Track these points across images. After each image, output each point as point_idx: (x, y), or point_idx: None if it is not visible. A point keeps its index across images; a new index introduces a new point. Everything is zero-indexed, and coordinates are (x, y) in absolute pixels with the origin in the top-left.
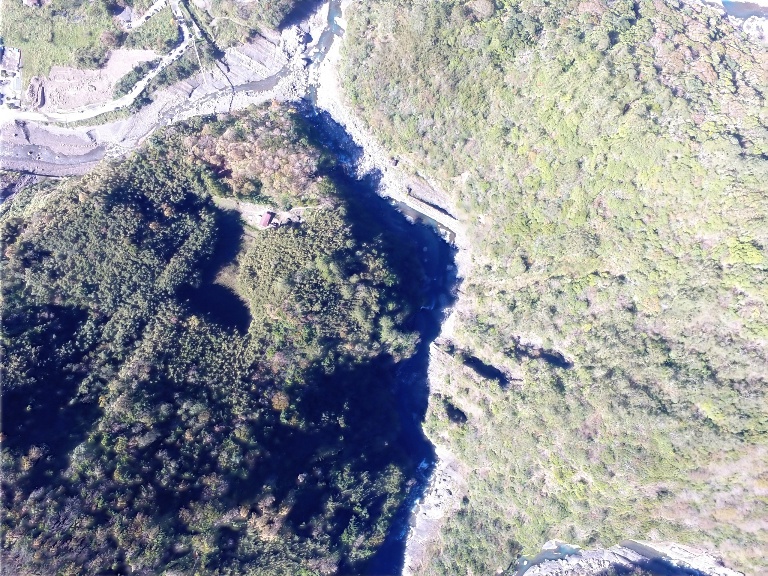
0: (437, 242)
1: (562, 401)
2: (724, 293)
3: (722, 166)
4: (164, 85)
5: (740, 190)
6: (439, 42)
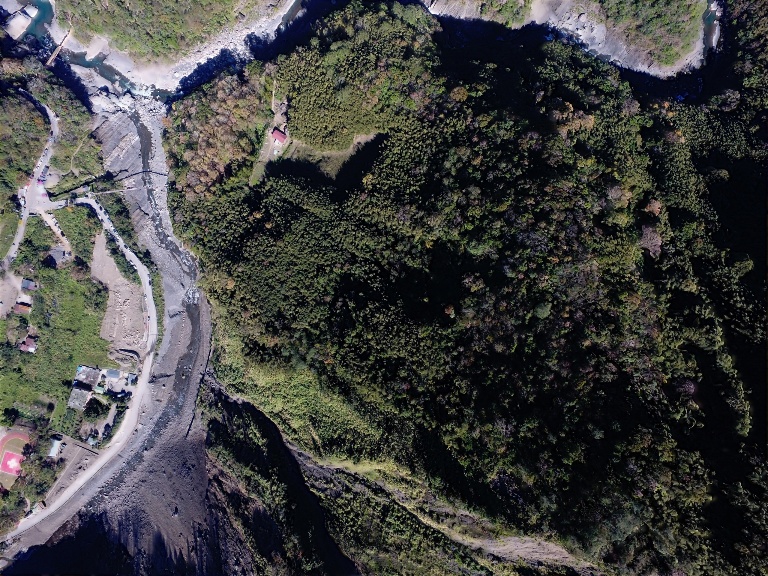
0: None
1: None
2: None
3: None
4: (133, 234)
5: None
6: None
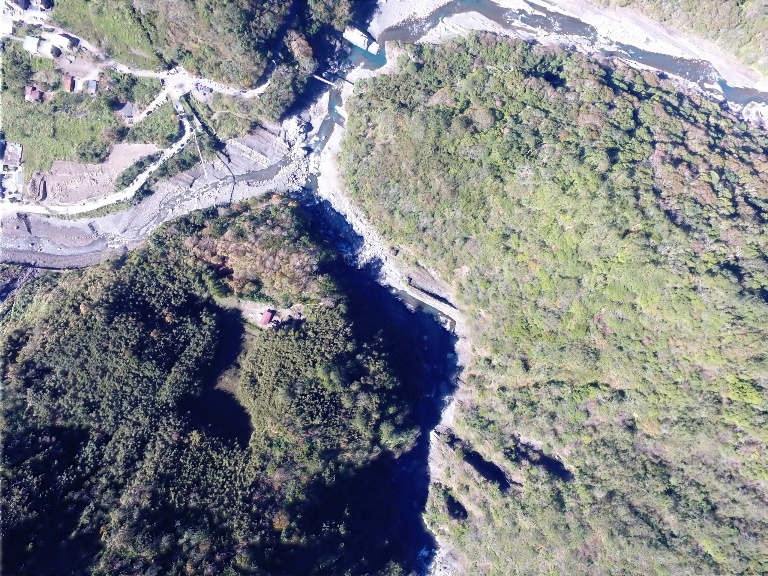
0: (437, 330)
1: (562, 518)
2: (724, 430)
3: (721, 302)
4: (165, 177)
5: (739, 328)
6: (439, 150)
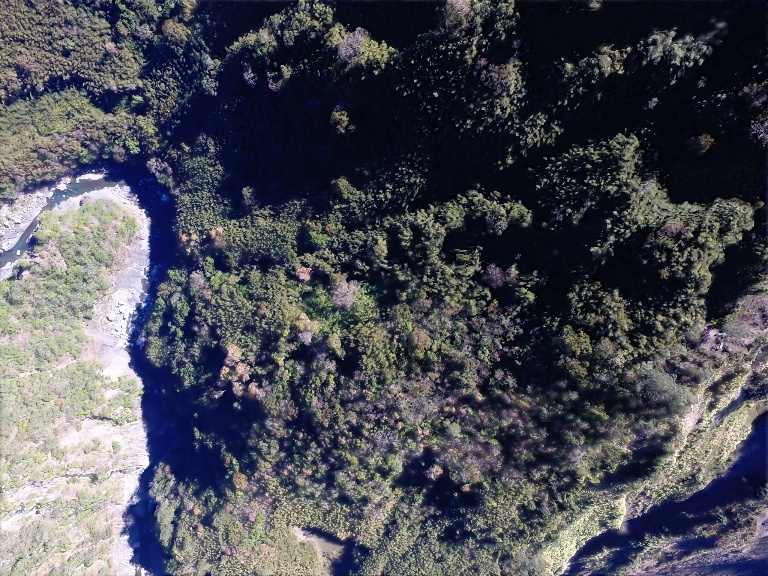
0: (154, 567)
1: None
2: None
3: None
4: None
5: None
6: None
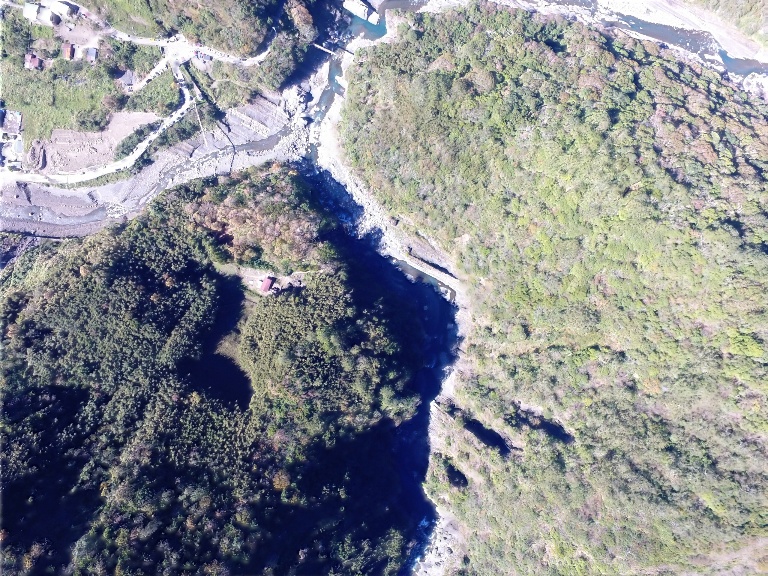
0: (438, 300)
1: (563, 479)
2: (724, 384)
3: (722, 256)
4: (165, 146)
5: (740, 281)
6: (439, 114)
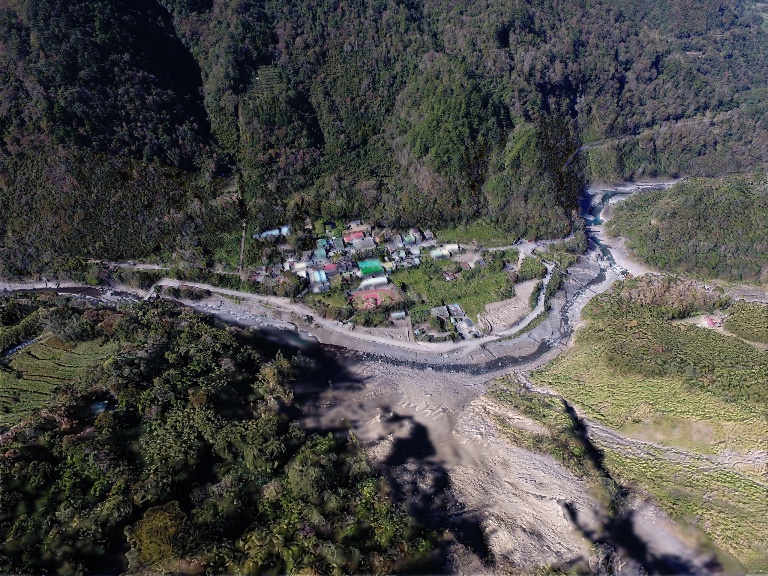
0: None
1: None
2: None
3: None
4: (552, 295)
5: None
6: None
